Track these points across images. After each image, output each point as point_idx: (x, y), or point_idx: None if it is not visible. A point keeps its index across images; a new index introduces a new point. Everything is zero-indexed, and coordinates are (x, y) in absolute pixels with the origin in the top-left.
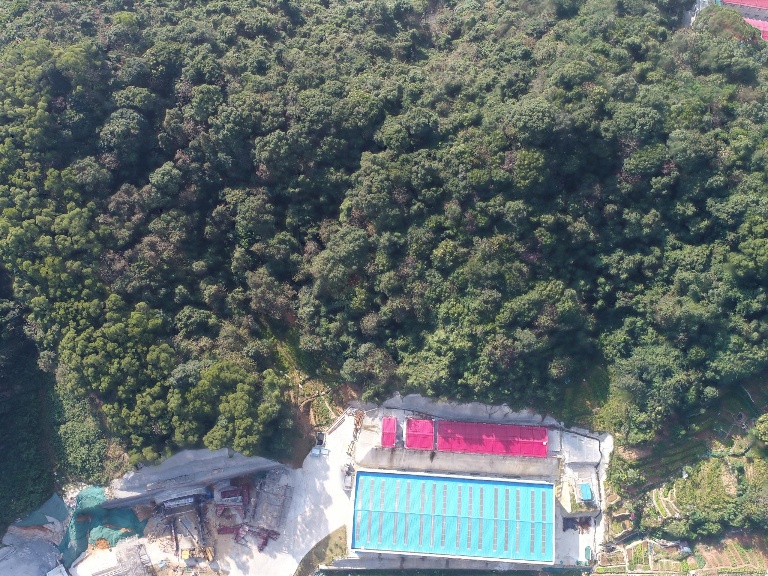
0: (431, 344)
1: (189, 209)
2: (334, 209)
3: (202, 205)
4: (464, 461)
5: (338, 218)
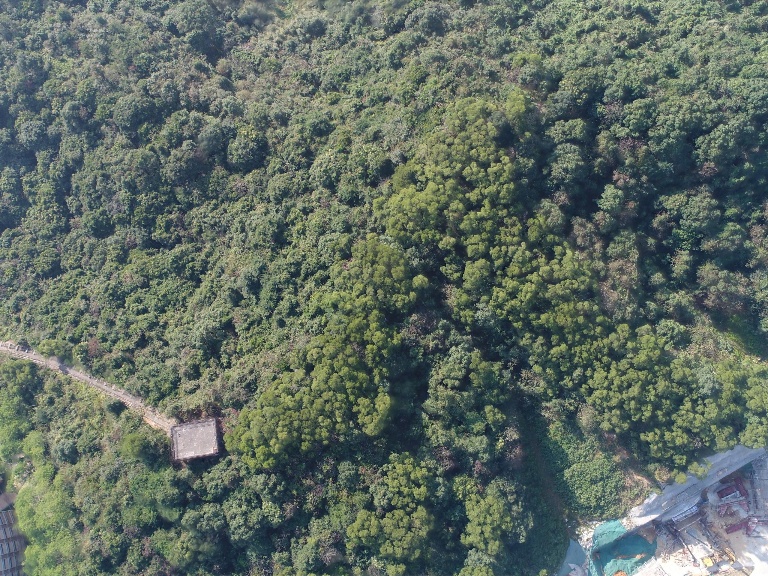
0: None
1: None
2: None
3: None
4: None
5: None
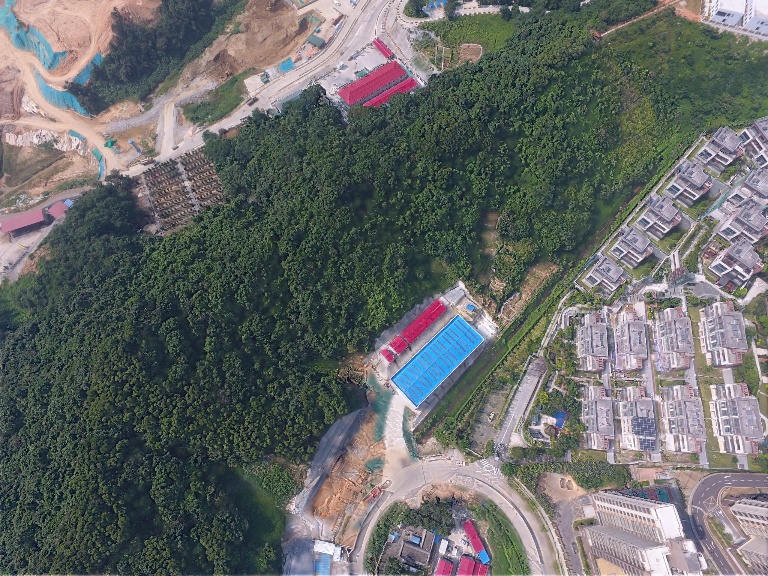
0: (371, 307)
1: (231, 350)
2: (288, 296)
3: (234, 345)
4: (422, 340)
5: (293, 298)
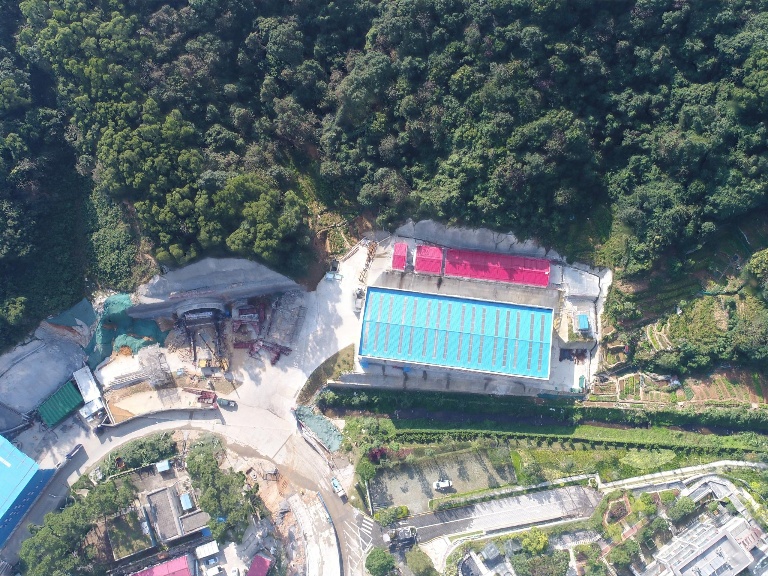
0: (444, 167)
1: (224, 37)
2: (360, 41)
3: (236, 37)
4: (469, 289)
5: (363, 51)
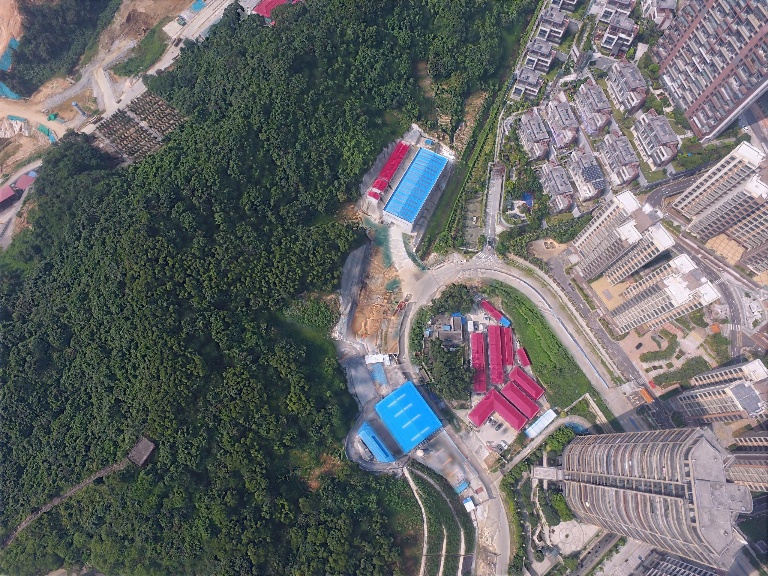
0: (347, 156)
1: None
2: (273, 167)
3: None
4: (398, 178)
5: None
